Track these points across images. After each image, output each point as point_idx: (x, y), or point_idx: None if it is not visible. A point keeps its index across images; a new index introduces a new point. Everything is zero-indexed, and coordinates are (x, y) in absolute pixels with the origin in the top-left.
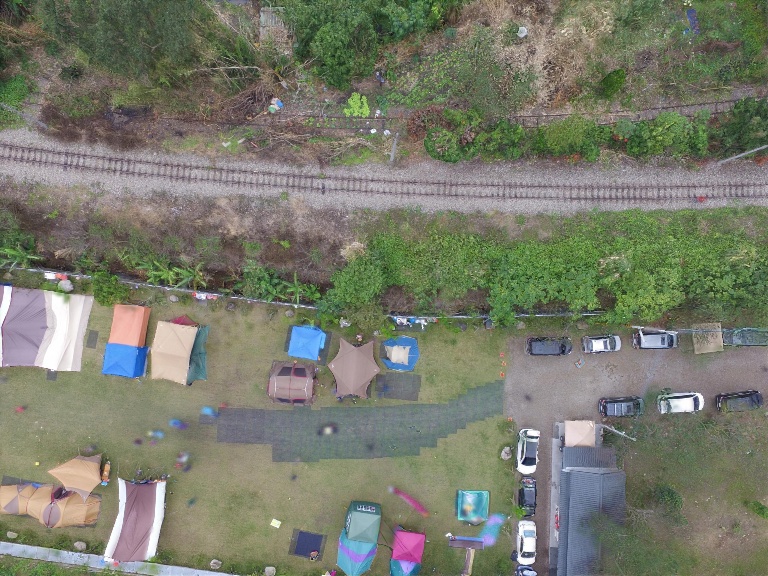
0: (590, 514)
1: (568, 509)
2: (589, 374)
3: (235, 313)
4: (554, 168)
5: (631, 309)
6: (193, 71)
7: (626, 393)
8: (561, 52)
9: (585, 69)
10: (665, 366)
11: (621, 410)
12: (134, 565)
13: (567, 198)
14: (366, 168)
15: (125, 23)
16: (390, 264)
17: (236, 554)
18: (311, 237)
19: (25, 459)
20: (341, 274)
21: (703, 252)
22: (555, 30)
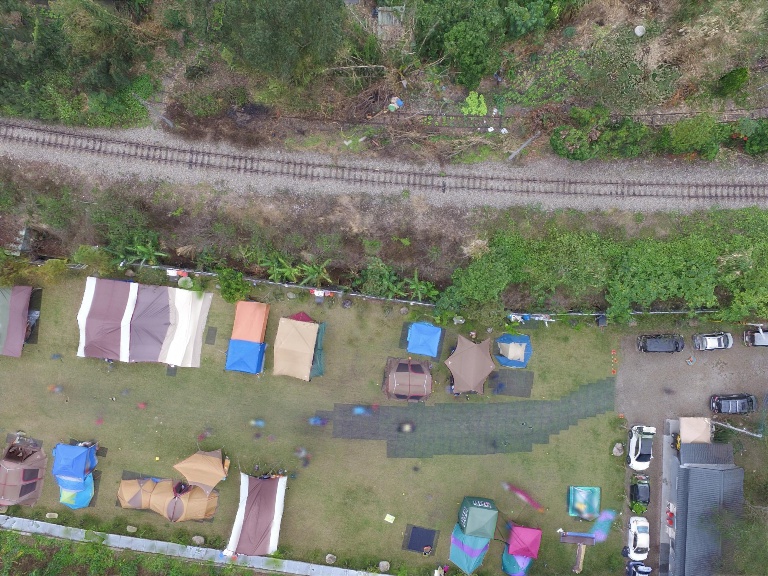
0: (710, 510)
1: (687, 505)
2: (699, 371)
3: (351, 310)
4: (671, 166)
5: (749, 306)
6: (325, 70)
7: (736, 390)
8: (677, 51)
9: (700, 68)
10: None
11: (736, 407)
12: (251, 559)
13: (685, 196)
14: (486, 166)
15: (282, 22)
16: (510, 261)
17: (350, 549)
18: (431, 235)
19: (145, 454)
20: (465, 271)
21: None
22: (671, 29)
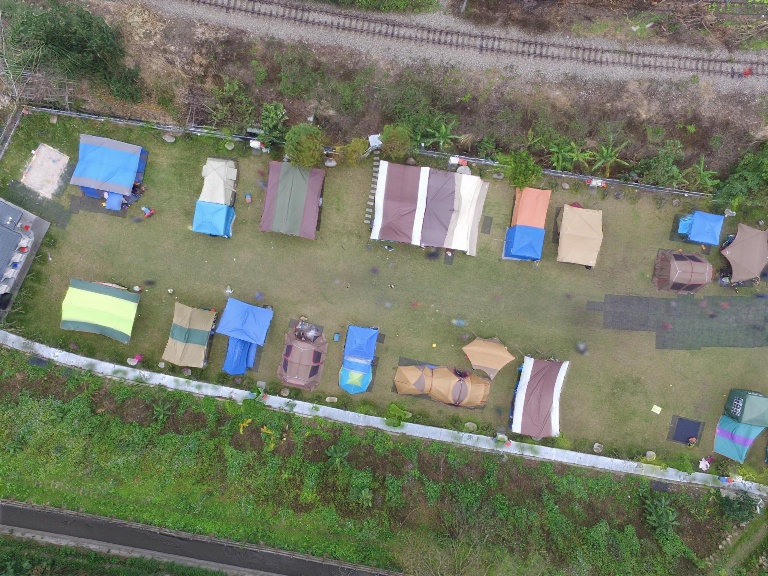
0: None
1: None
2: None
3: (623, 201)
4: None
5: None
6: None
7: None
8: None
9: None
10: None
11: None
12: (520, 447)
13: None
14: None
15: None
16: None
17: (616, 439)
18: (718, 121)
19: (421, 341)
20: (760, 155)
21: None
22: None
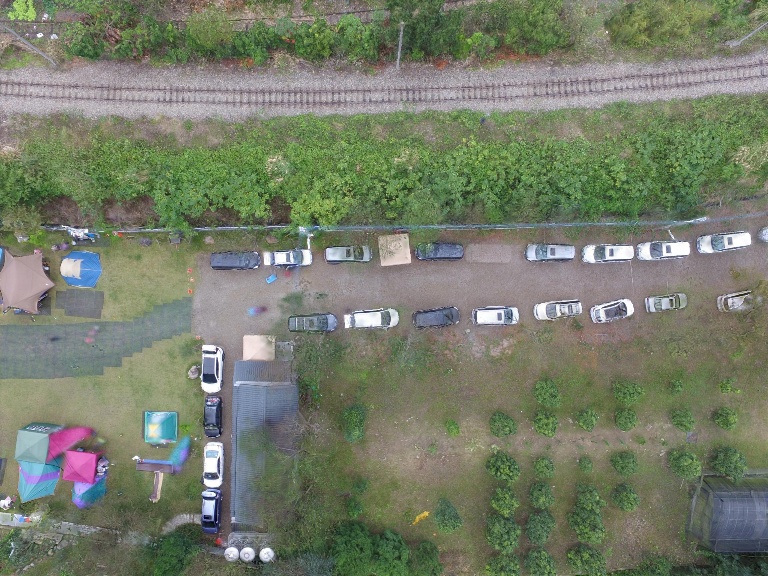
0: (255, 428)
1: (236, 424)
2: (282, 291)
3: None
4: (226, 72)
5: (302, 217)
6: None
7: (321, 310)
8: None
9: None
10: (362, 282)
11: (302, 324)
12: None
13: (236, 102)
14: (26, 72)
15: None
16: (48, 170)
17: None
18: None
19: None
20: None
21: (378, 158)
22: None
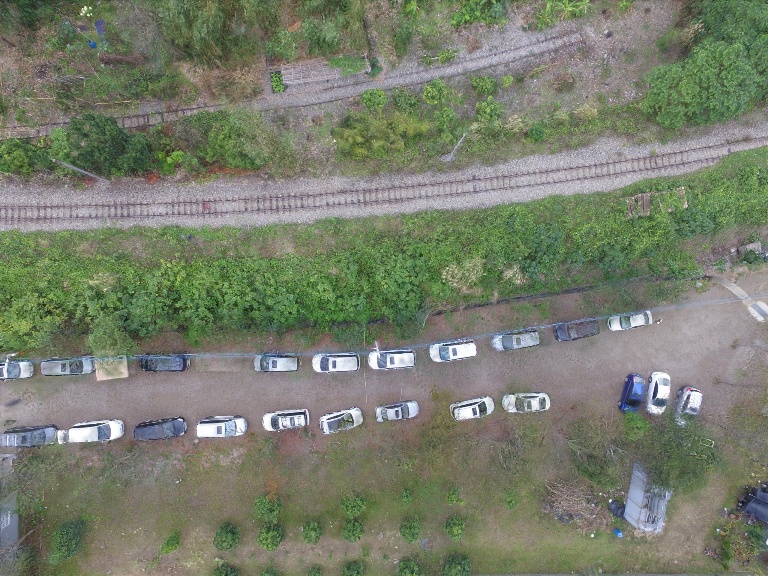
0: None
1: None
2: (4, 402)
3: None
4: None
5: None
6: None
7: (44, 421)
8: None
9: None
10: (89, 393)
11: (14, 441)
12: None
13: None
14: None
15: None
16: None
17: None
18: None
19: None
20: None
21: (83, 275)
22: None
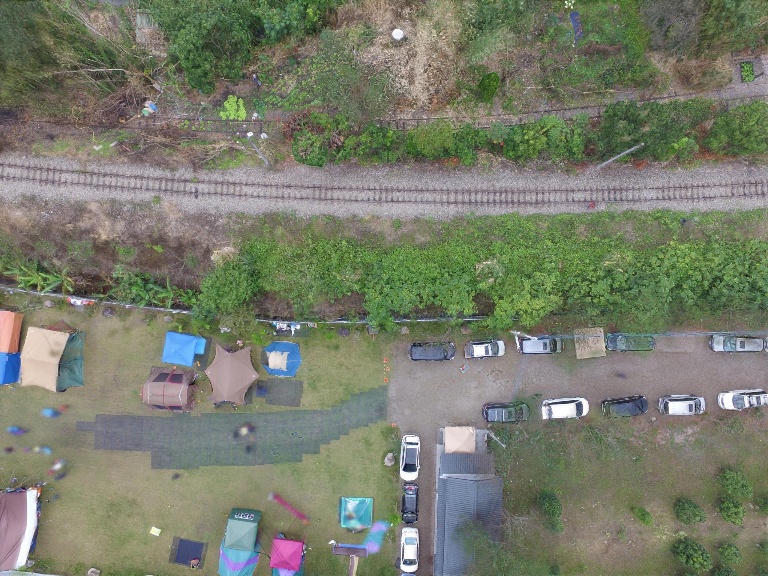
0: (465, 521)
1: (444, 516)
2: (474, 379)
3: (113, 318)
4: (432, 172)
5: (508, 314)
6: (53, 73)
7: (511, 398)
8: (440, 55)
9: (466, 72)
10: (551, 371)
11: (502, 416)
12: (10, 574)
13: (444, 202)
14: (240, 172)
15: None
16: (264, 269)
17: (115, 563)
18: (184, 242)
19: None
20: None
21: (581, 257)
22: None
